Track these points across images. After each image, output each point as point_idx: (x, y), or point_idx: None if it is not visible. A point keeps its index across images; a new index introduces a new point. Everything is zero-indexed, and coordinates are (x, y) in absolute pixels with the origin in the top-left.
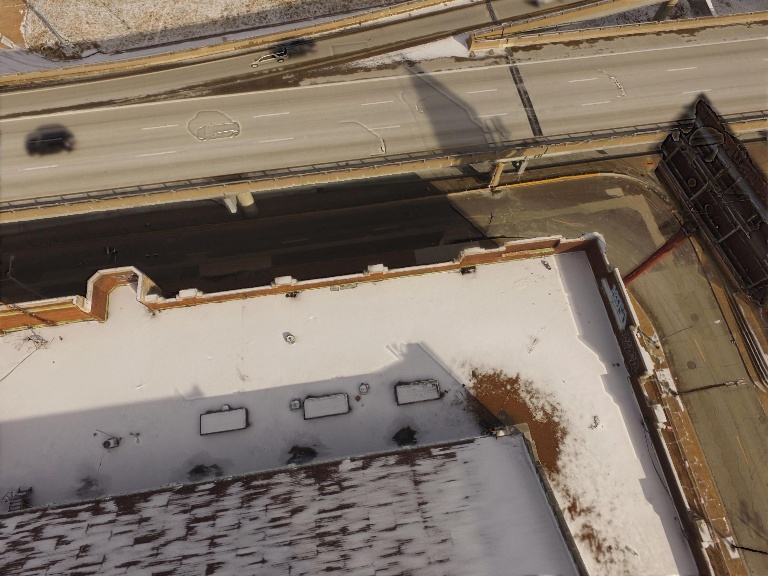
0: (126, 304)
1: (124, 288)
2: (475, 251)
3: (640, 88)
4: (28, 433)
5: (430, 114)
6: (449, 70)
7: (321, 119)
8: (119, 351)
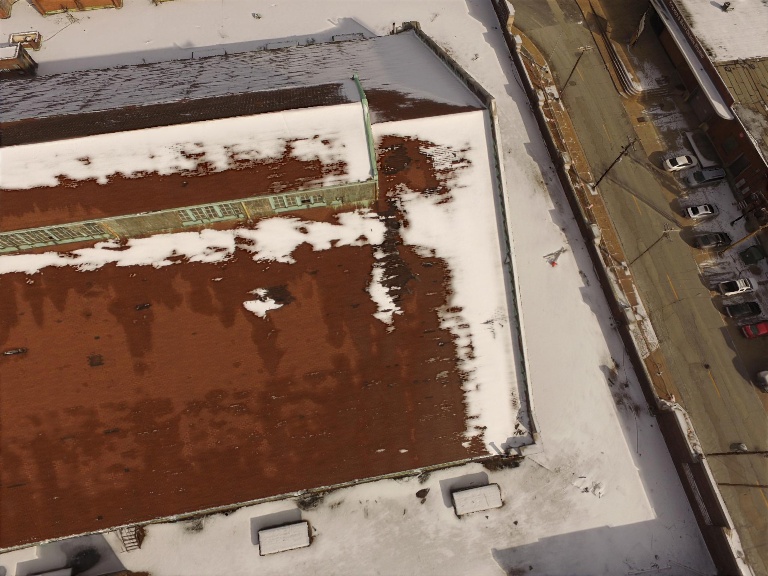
0: None
1: None
2: None
3: None
4: (69, 67)
5: None
6: None
7: None
8: (132, 24)
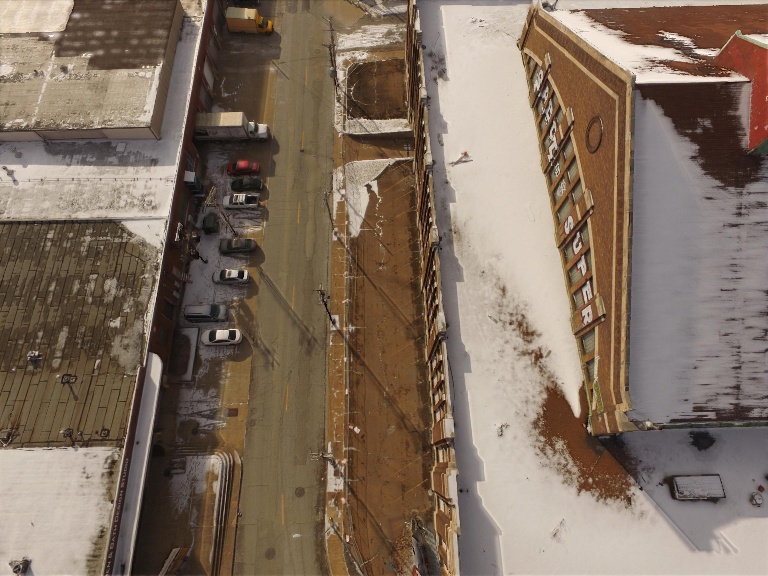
0: None
1: None
2: None
3: None
4: None
5: None
6: None
7: None
8: None
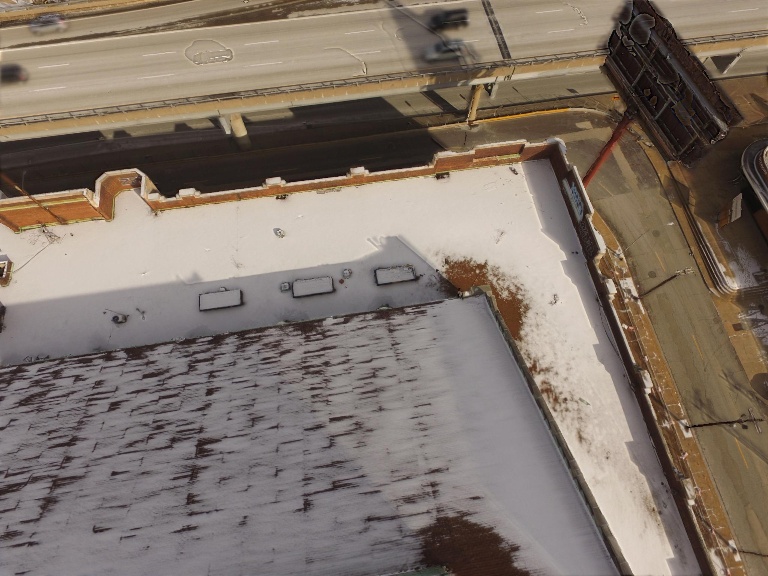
0: (131, 206)
1: (128, 193)
2: (447, 154)
3: (601, 18)
4: (44, 312)
5: (408, 41)
6: (426, 4)
7: (308, 46)
8: (125, 245)
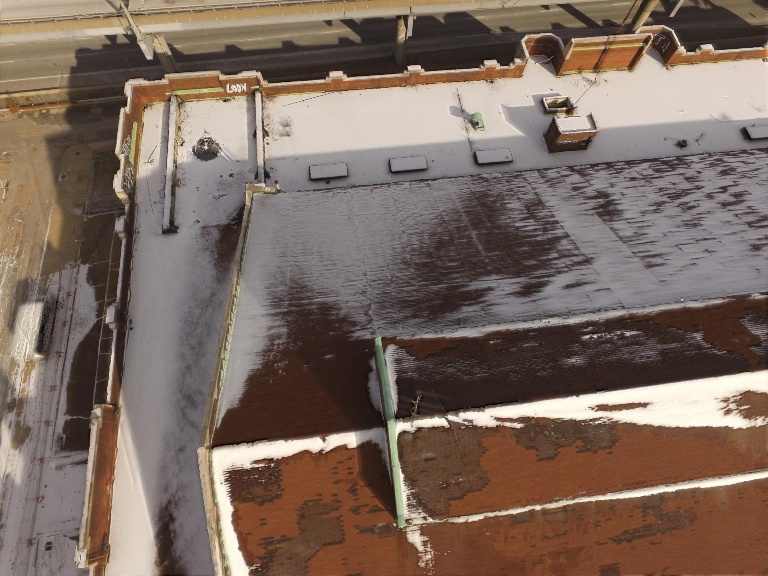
0: (642, 61)
1: None
2: None
3: None
4: (613, 137)
5: None
6: None
7: None
8: (654, 90)
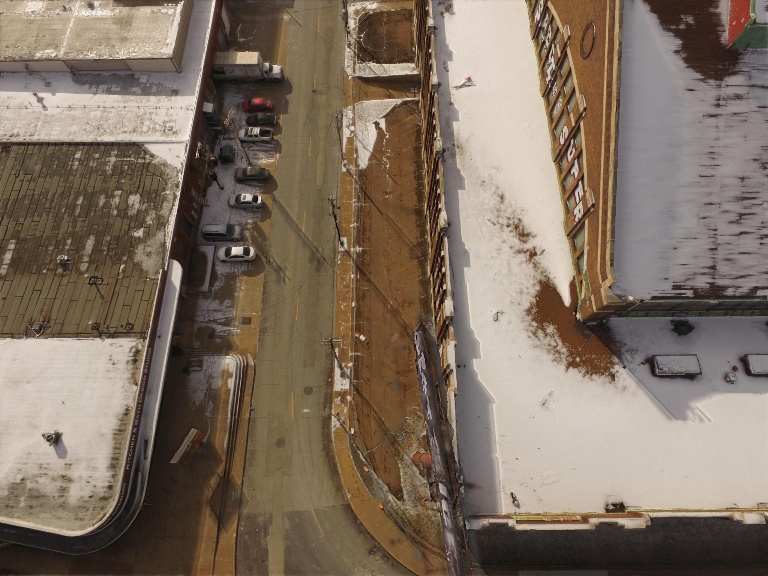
0: None
1: None
2: (632, 522)
3: None
4: None
5: None
6: None
7: None
8: None
